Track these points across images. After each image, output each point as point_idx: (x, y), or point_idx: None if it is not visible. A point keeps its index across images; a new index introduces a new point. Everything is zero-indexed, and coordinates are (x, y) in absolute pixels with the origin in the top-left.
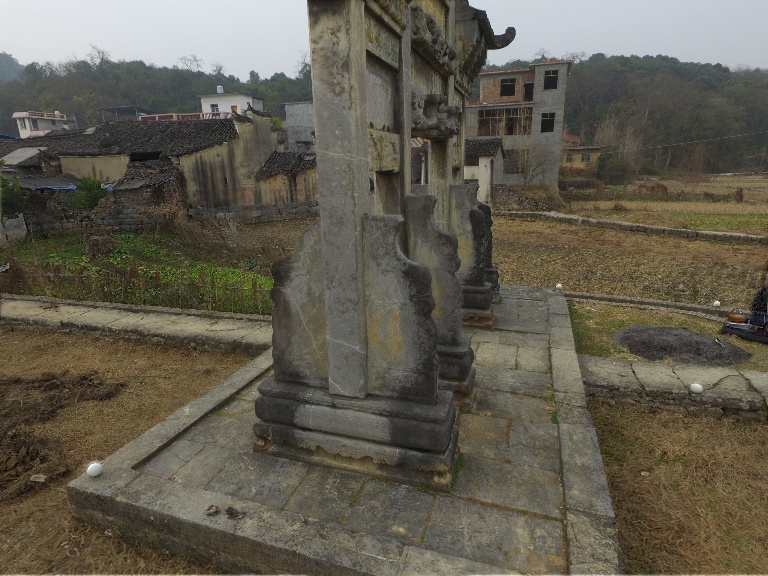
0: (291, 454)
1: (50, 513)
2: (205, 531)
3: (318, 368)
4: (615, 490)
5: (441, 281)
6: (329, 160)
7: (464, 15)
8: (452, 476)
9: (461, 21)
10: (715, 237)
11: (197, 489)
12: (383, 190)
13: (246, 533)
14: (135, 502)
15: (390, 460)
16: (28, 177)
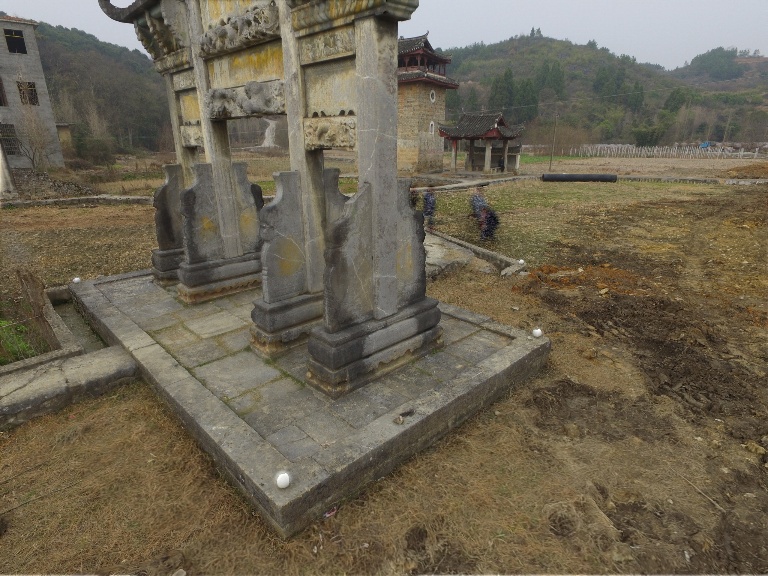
0: (363, 382)
1: (247, 571)
2: (410, 431)
3: (365, 306)
4: None
5: None
6: (385, 140)
7: None
8: None
9: None
10: (269, 200)
11: (364, 428)
12: (311, 165)
13: (431, 411)
14: (354, 459)
15: (419, 344)
16: None
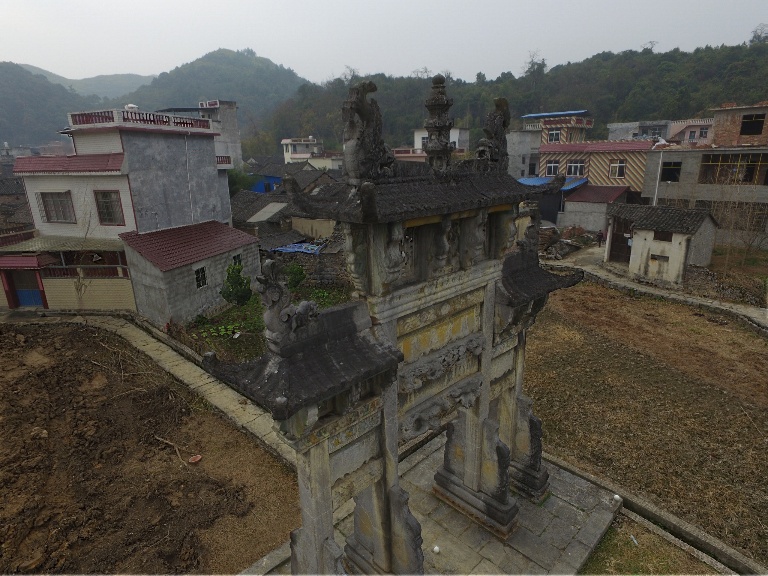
0: None
1: None
2: None
3: None
4: None
5: (408, 549)
6: (305, 512)
7: (502, 300)
8: None
9: (499, 304)
10: None
11: None
12: None
13: None
14: None
15: None
16: (270, 236)
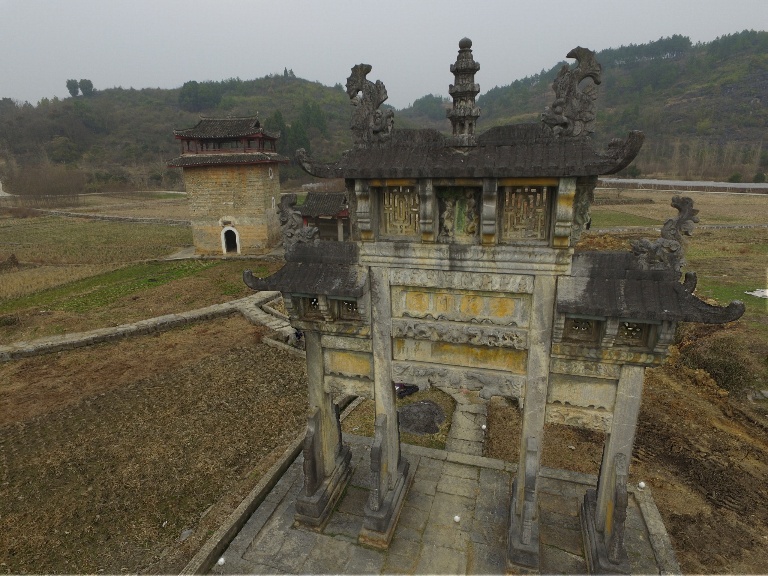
0: None
1: None
2: None
3: None
4: None
5: None
6: None
7: None
8: None
9: None
10: (170, 326)
11: None
12: None
13: None
14: None
15: None
16: None
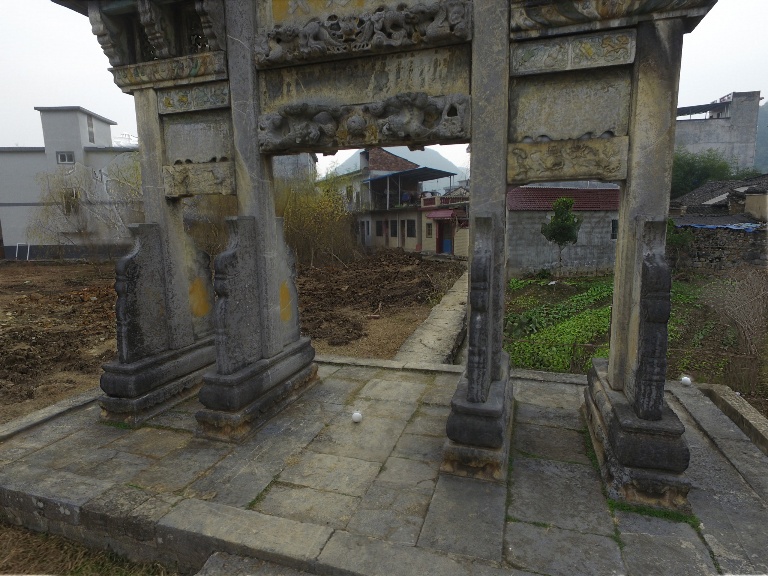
0: None
1: None
2: None
3: None
4: (23, 545)
5: None
6: None
7: None
8: (109, 420)
9: None
10: None
11: None
12: None
13: None
14: None
15: None
16: (698, 216)
